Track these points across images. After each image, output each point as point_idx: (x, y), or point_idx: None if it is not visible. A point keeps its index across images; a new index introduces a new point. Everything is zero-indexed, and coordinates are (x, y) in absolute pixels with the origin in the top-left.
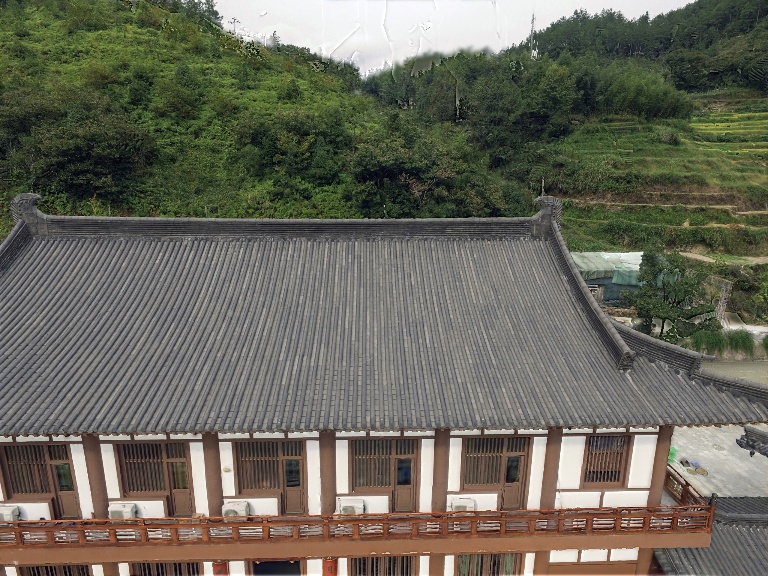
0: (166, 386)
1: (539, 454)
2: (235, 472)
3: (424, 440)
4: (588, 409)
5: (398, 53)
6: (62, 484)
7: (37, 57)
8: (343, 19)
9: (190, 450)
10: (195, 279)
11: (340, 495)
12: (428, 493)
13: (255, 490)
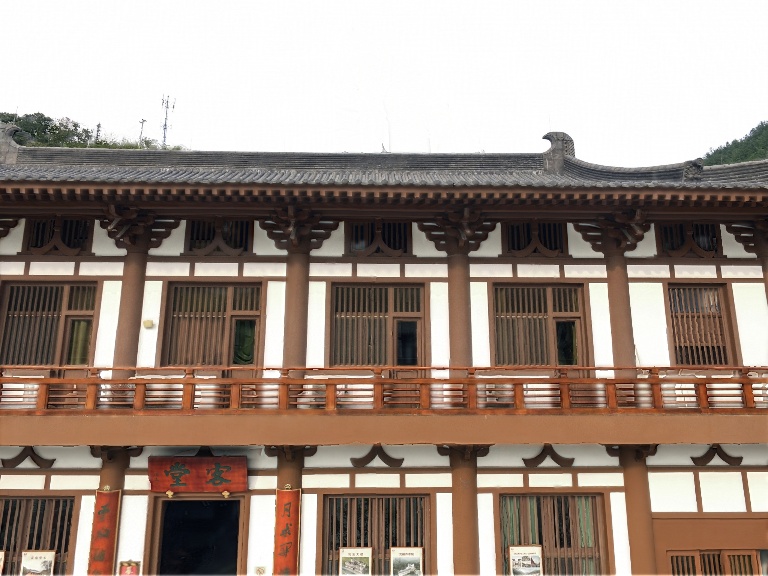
0: None
1: (600, 310)
2: (160, 329)
3: (433, 284)
4: None
5: None
6: None
7: None
8: None
9: (102, 293)
10: None
11: (311, 373)
12: (443, 372)
13: (185, 366)
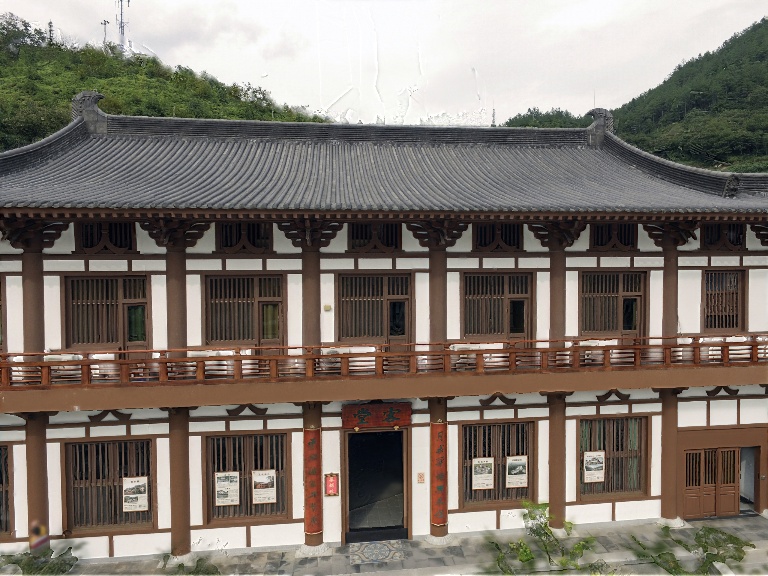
0: (273, 195)
1: (657, 291)
2: (336, 311)
3: (539, 273)
4: None
5: (388, 112)
6: (131, 334)
7: (48, 95)
8: (338, 82)
9: (287, 283)
10: (268, 162)
11: (450, 341)
12: (545, 338)
13: (355, 338)
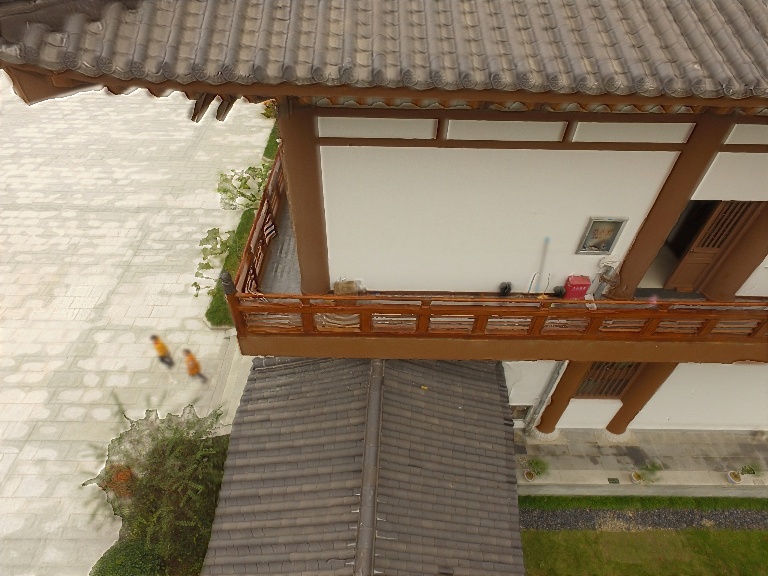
0: None
1: None
2: None
3: None
4: None
5: None
6: None
7: None
8: None
9: None
10: None
11: None
12: None
13: None
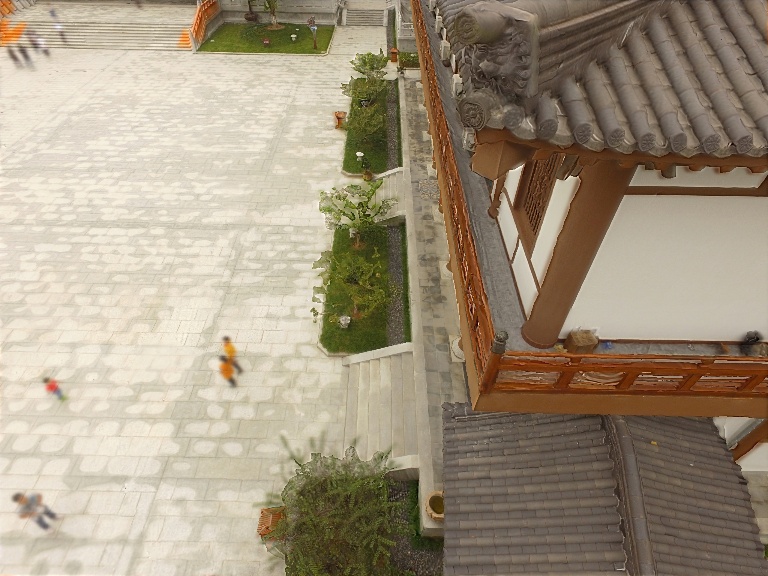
0: None
1: None
2: None
3: None
4: None
5: None
6: None
7: None
8: None
9: None
10: None
11: None
12: None
13: None
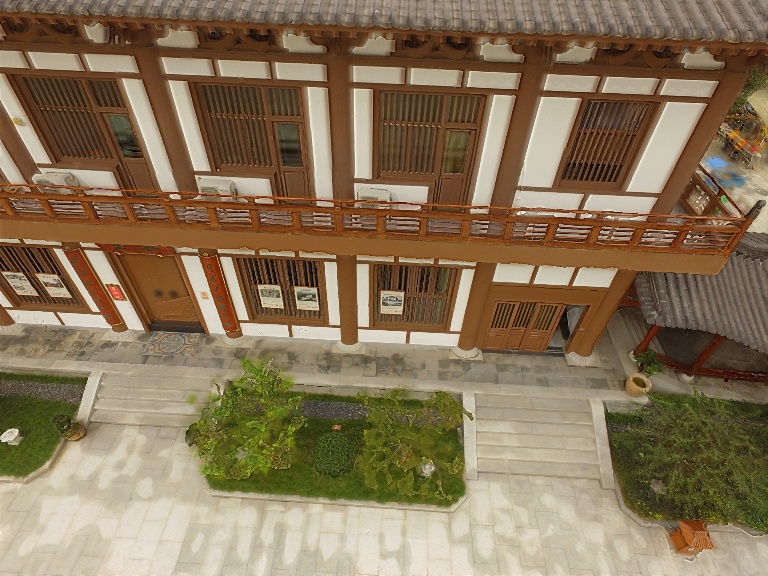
0: None
1: (498, 126)
2: (35, 127)
3: (311, 89)
4: (594, 8)
5: None
6: None
7: None
8: None
9: None
10: None
11: (200, 173)
12: (326, 179)
13: (80, 159)
